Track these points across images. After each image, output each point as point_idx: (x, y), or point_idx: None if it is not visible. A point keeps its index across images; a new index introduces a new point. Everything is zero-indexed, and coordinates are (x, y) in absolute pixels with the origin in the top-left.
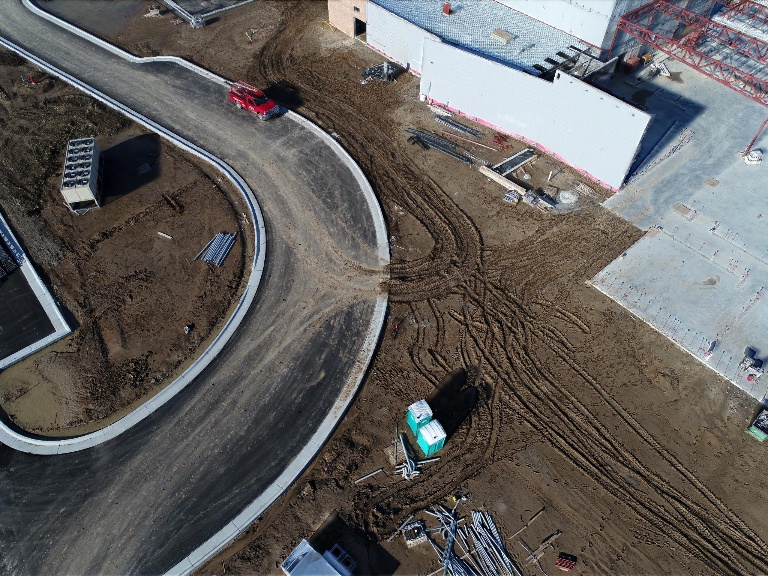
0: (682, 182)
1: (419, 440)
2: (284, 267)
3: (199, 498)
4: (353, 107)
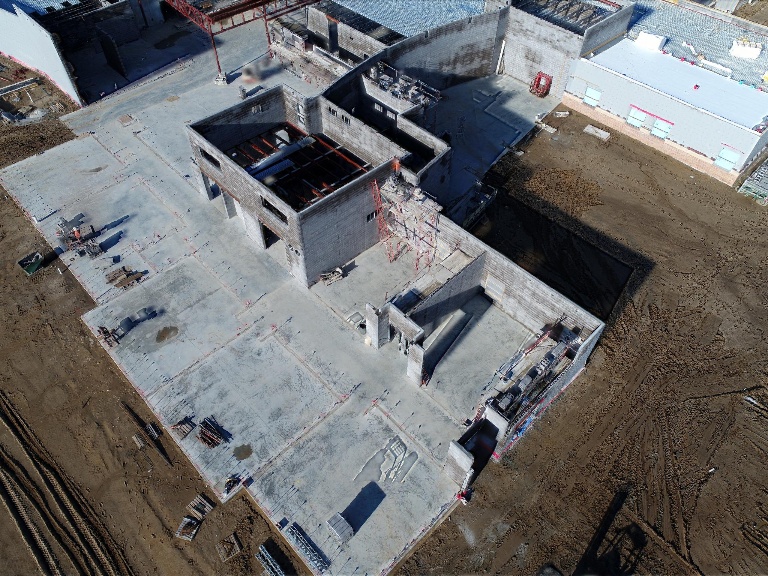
0: (146, 99)
1: None
2: None
3: None
4: None
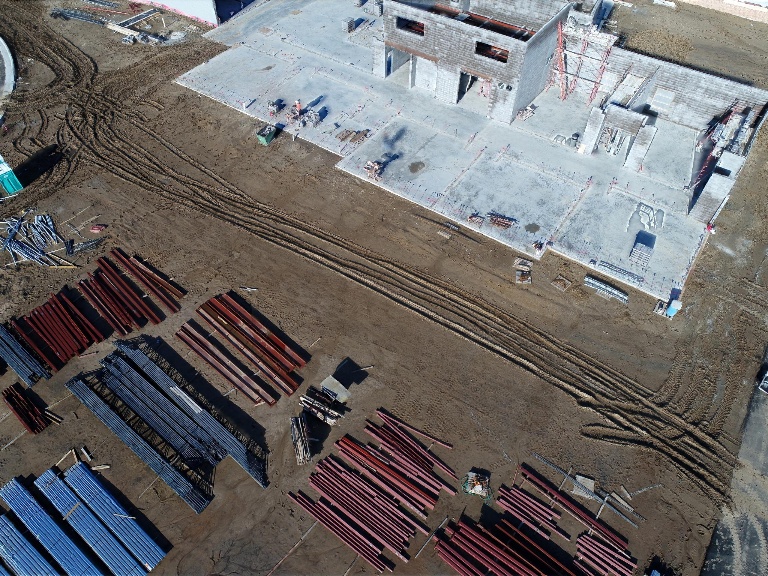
0: (272, 15)
1: None
2: None
3: None
4: (8, 0)
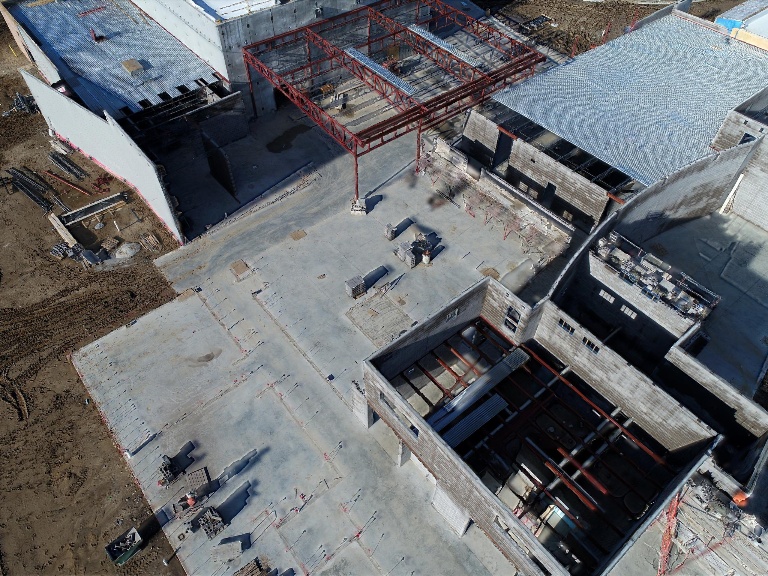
0: (264, 234)
1: None
2: None
3: None
4: None
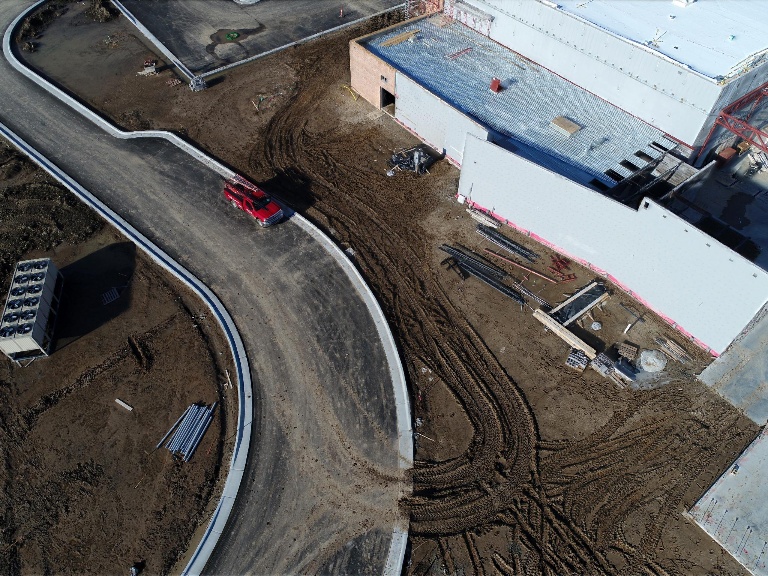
0: None
1: None
2: (272, 465)
3: None
4: (375, 210)
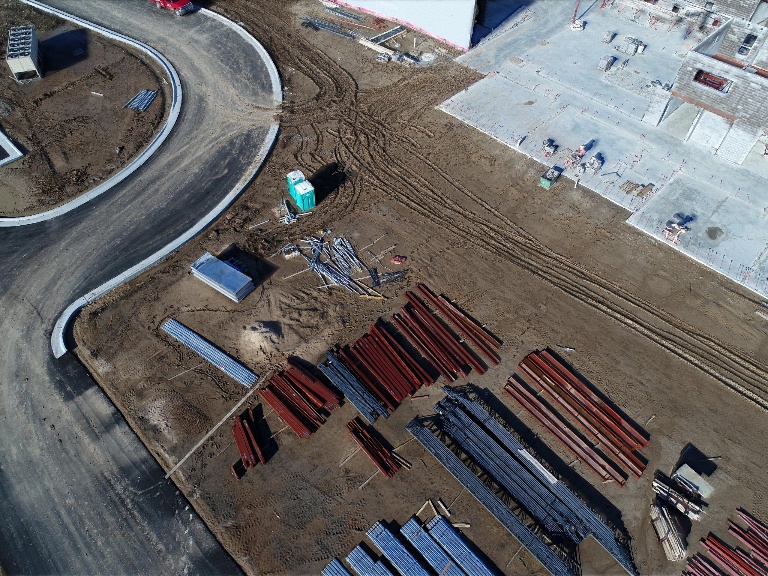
0: (520, 44)
1: (297, 201)
2: (197, 109)
3: (130, 243)
4: (257, 4)
